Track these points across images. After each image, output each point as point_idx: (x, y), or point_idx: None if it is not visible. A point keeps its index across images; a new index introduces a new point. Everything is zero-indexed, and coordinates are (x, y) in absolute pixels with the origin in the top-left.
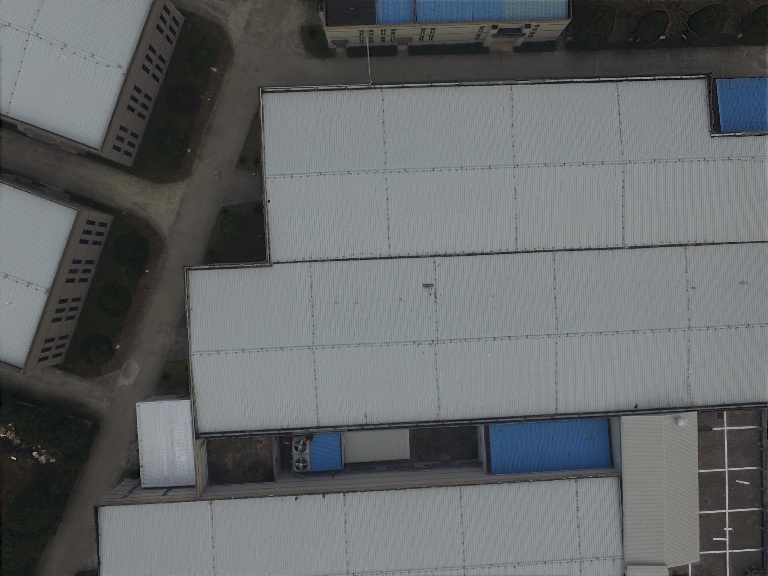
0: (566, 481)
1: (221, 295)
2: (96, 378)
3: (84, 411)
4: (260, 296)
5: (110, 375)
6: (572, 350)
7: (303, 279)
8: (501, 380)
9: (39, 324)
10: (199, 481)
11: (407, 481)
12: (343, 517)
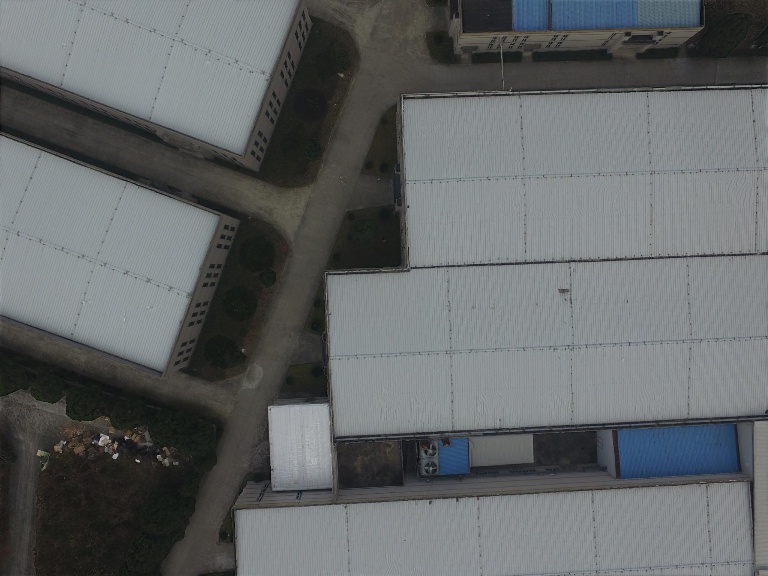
0: (697, 486)
1: (359, 300)
2: (220, 381)
3: (208, 414)
4: (398, 301)
5: (234, 378)
6: (705, 355)
7: (440, 284)
8: (634, 385)
9: (181, 328)
10: (334, 485)
11: (538, 485)
12: (477, 521)
